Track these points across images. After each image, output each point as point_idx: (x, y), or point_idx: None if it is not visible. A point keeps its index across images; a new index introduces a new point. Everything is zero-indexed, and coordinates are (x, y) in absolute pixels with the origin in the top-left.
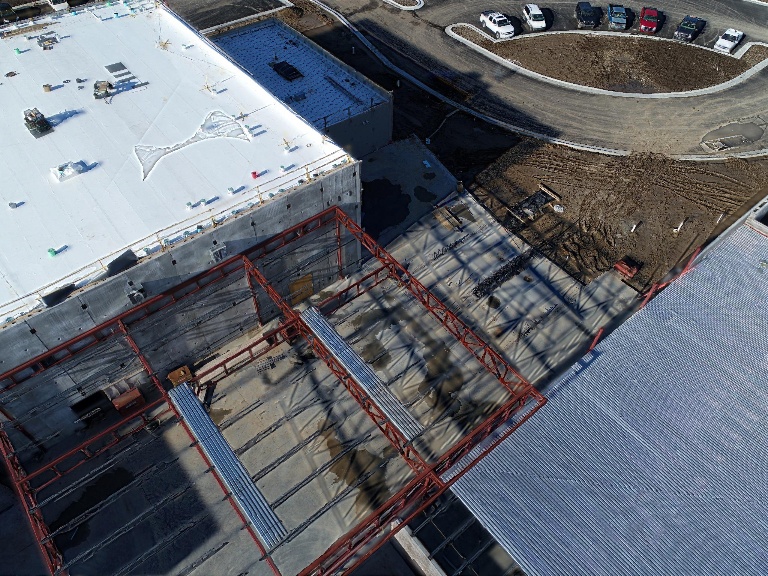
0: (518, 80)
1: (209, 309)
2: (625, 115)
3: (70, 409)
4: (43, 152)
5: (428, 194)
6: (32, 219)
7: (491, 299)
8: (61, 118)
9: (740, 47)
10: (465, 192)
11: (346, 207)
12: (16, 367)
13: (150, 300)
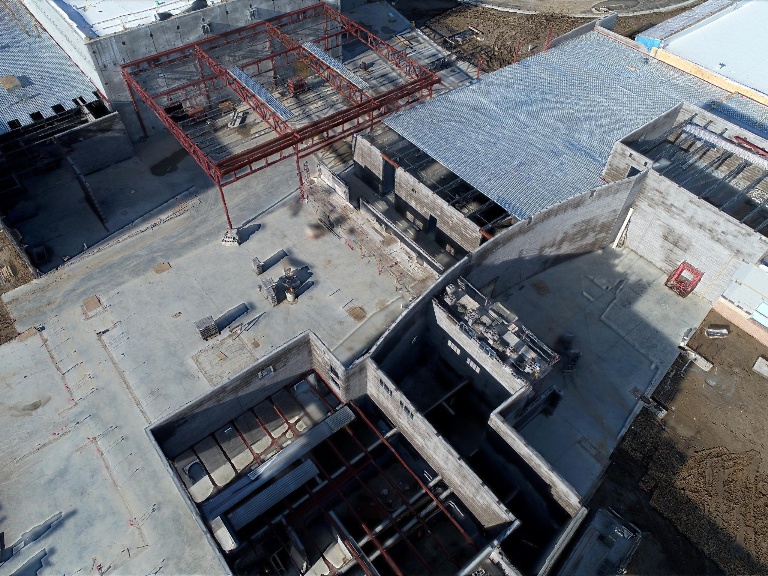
0: None
1: (245, 60)
2: None
3: (163, 109)
4: None
5: (390, 30)
6: None
7: None
8: None
9: None
10: (416, 29)
11: None
12: (140, 59)
13: (212, 37)
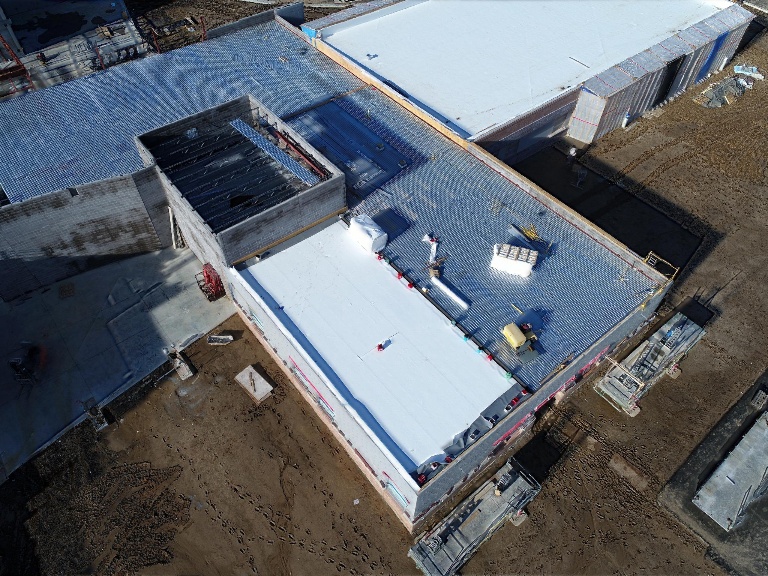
0: None
1: None
2: None
3: None
4: None
5: (101, 20)
6: None
7: None
8: None
9: None
10: (129, 20)
11: None
12: None
13: None
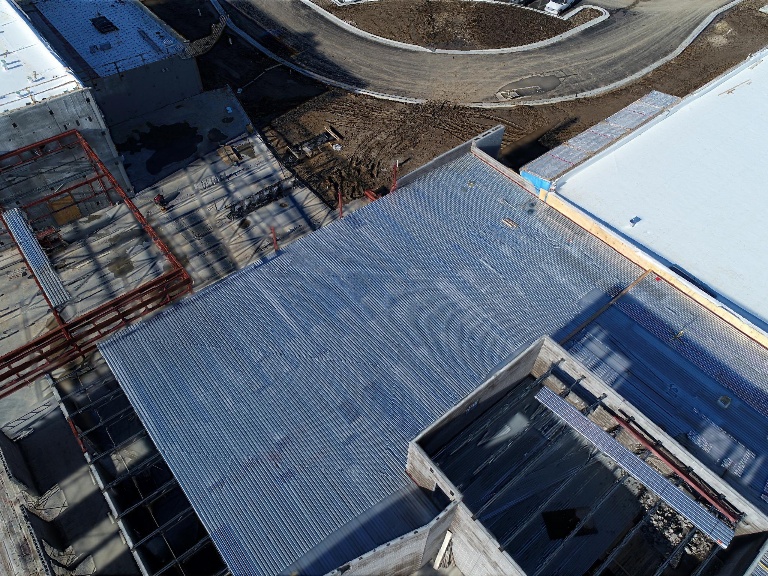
0: (348, 39)
1: None
2: (436, 69)
3: None
4: None
5: (220, 135)
6: None
7: (243, 221)
8: None
9: (572, 10)
10: (255, 133)
11: (90, 132)
12: None
13: None
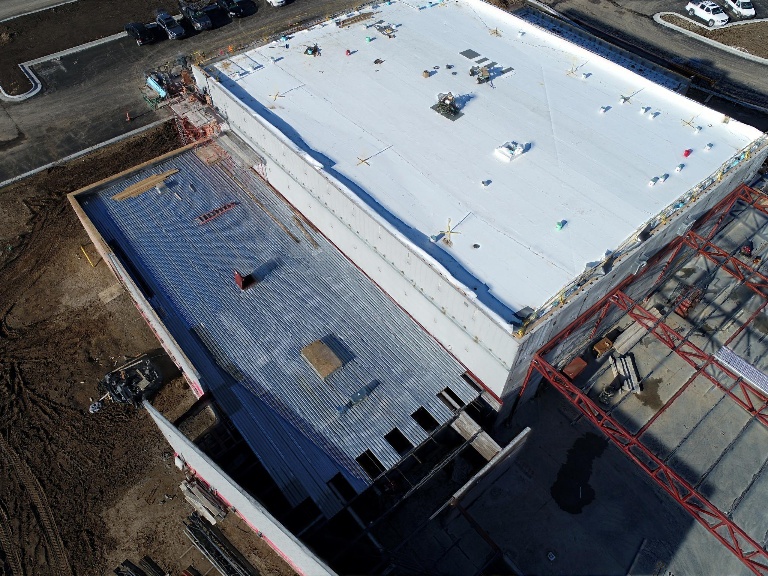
0: (752, 66)
1: None
2: None
3: (541, 377)
4: (470, 134)
5: None
6: (511, 196)
7: None
8: (461, 102)
9: None
10: (767, 173)
11: None
12: (559, 333)
13: None
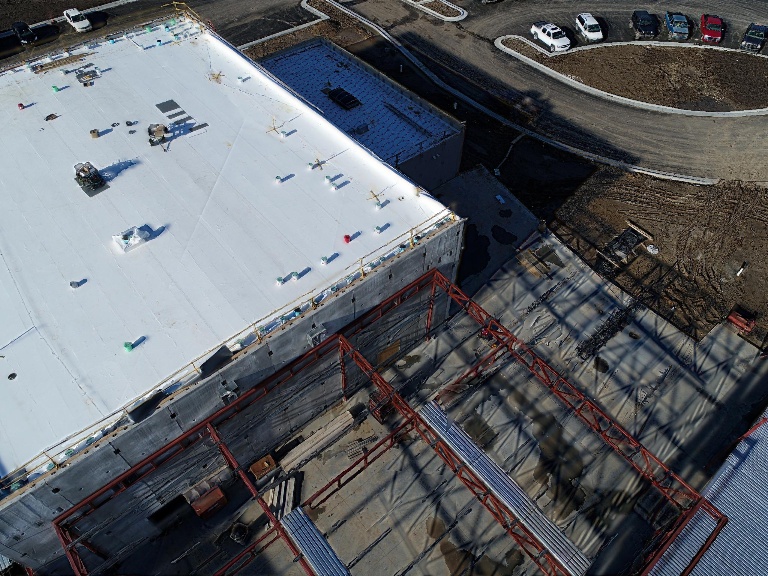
0: (582, 99)
1: (298, 393)
2: (703, 137)
3: (147, 520)
4: (100, 214)
5: (507, 235)
6: (99, 302)
7: (597, 361)
8: (115, 171)
9: None
10: (548, 232)
11: (444, 268)
12: (95, 491)
13: (241, 396)
